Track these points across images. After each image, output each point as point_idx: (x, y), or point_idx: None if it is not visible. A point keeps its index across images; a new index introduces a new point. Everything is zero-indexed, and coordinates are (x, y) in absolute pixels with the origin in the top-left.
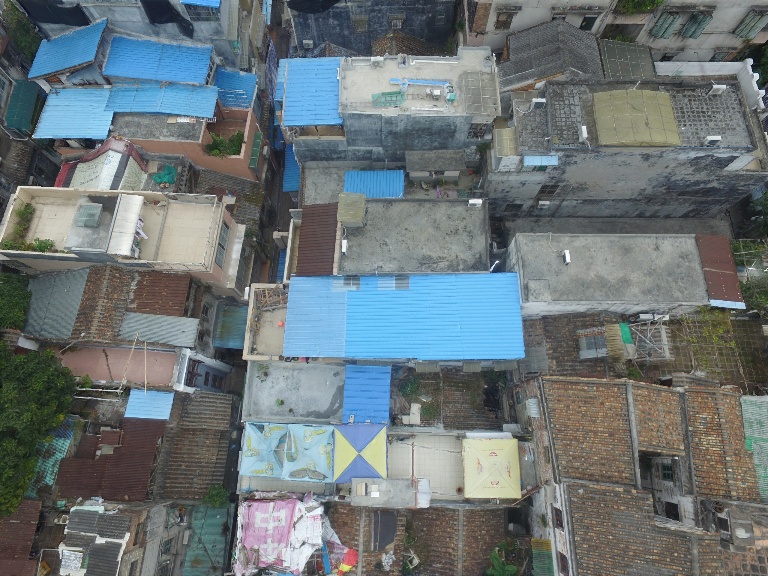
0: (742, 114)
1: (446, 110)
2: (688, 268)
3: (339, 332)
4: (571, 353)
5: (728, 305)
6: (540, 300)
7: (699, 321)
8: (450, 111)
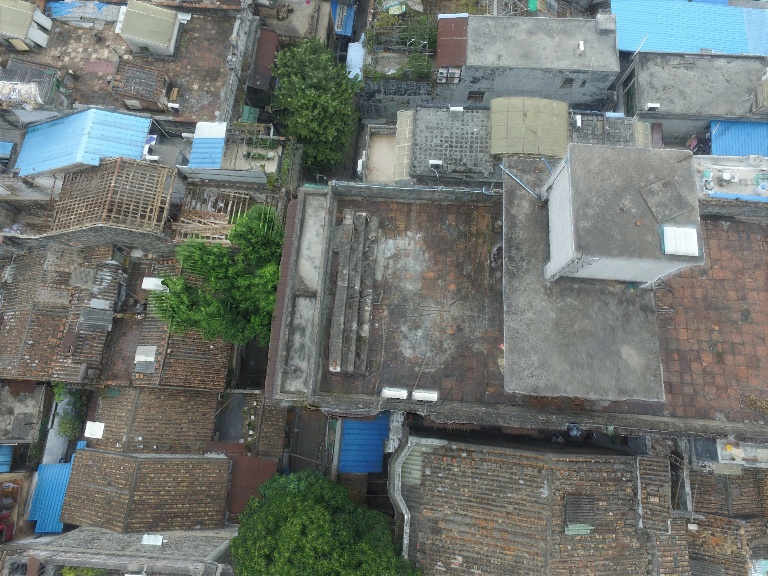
0: (415, 142)
1: (709, 166)
2: (478, 41)
3: (751, 24)
4: (558, 16)
5: (453, 15)
6: (607, 15)
7: (477, 7)
8: (705, 164)
